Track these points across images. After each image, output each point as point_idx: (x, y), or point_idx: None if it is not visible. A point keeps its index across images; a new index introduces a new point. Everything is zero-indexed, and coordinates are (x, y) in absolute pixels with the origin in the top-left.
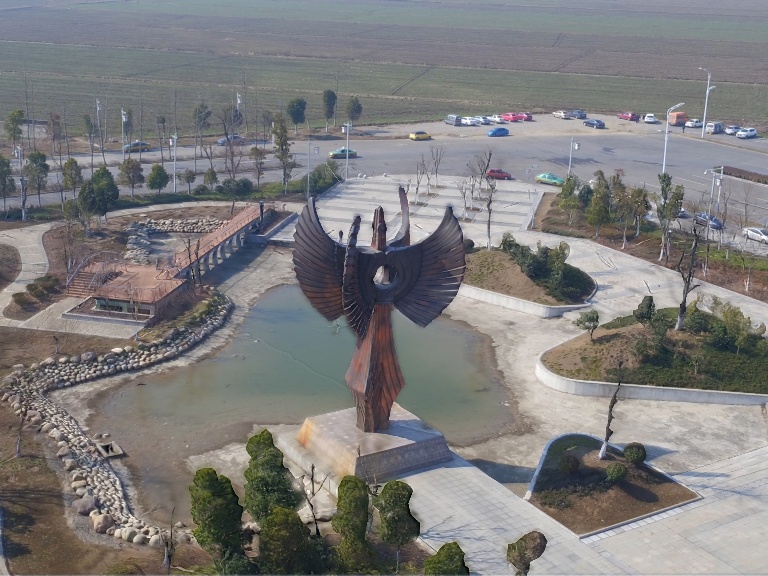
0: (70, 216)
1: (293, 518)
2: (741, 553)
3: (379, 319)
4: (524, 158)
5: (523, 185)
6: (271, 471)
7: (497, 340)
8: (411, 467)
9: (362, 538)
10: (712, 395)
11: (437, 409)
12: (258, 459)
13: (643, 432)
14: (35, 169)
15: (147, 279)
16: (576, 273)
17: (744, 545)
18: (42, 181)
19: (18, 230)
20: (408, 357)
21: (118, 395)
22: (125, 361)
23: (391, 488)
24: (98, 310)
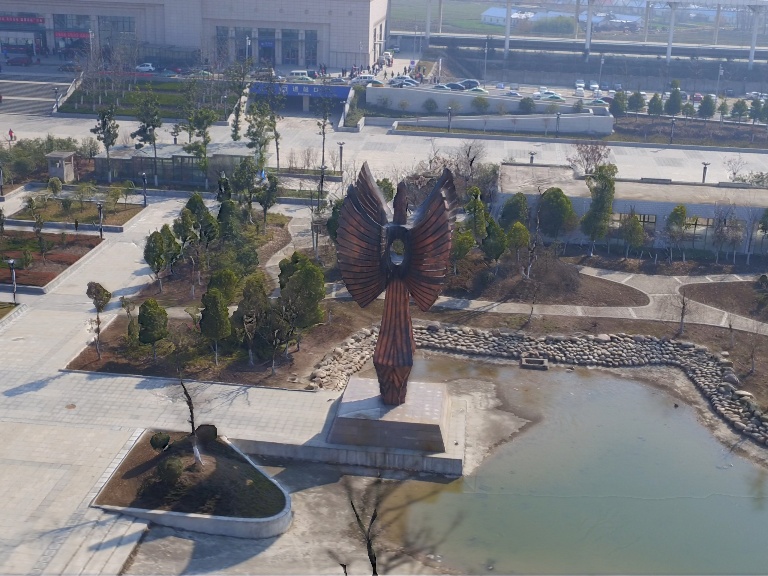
0: None
1: (248, 285)
2: (19, 473)
3: None
4: None
5: None
6: None
7: None
8: None
9: None
10: None
11: (474, 517)
12: None
13: None
14: None
15: None
16: None
17: (21, 480)
18: None
19: None
20: (657, 571)
21: (656, 392)
22: None
23: None
24: None
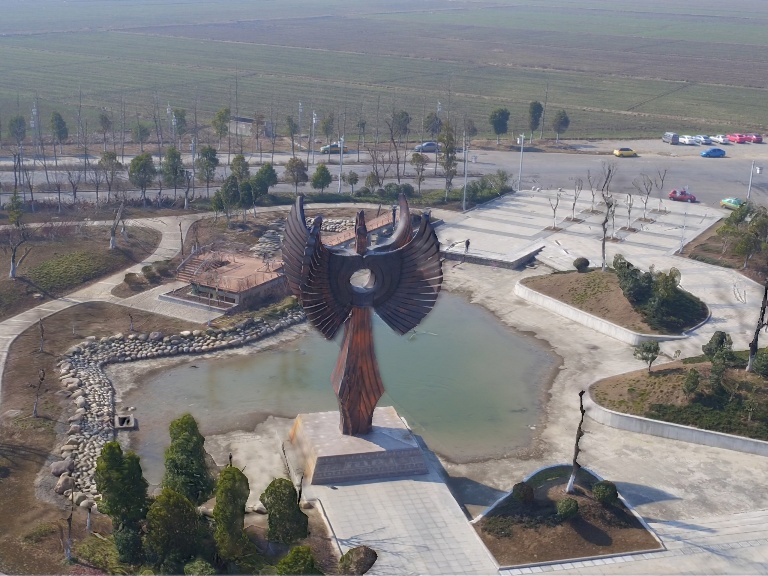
0: (217, 208)
1: (177, 501)
2: None
3: (358, 322)
4: (725, 181)
5: (704, 208)
6: (182, 454)
7: (568, 363)
8: (378, 475)
9: (232, 529)
10: (759, 445)
11: (459, 424)
12: (174, 441)
13: (658, 474)
14: (205, 162)
15: (249, 270)
16: (686, 302)
17: None
18: (210, 174)
19: (174, 218)
20: (466, 370)
21: (168, 374)
22: (189, 344)
23: (273, 485)
24: (192, 295)
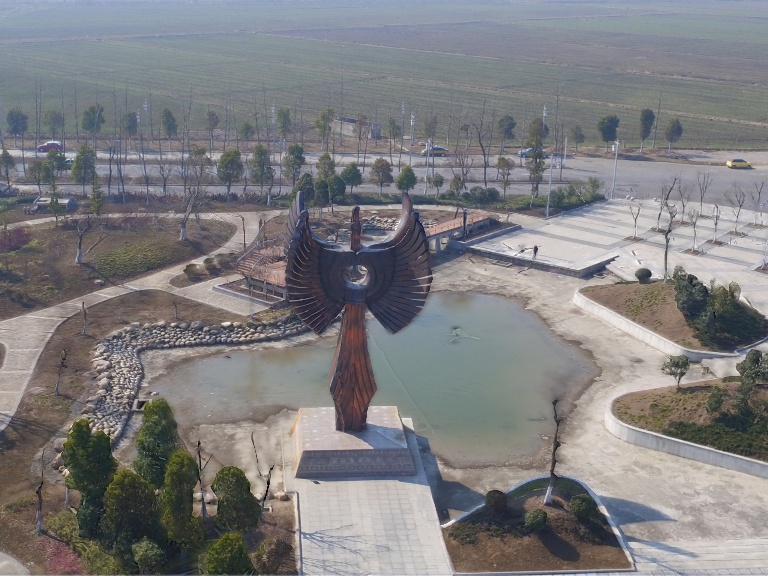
0: None
1: (132, 481)
2: None
3: (352, 319)
4: None
5: None
6: (150, 437)
7: (605, 375)
8: (364, 472)
9: (177, 513)
10: None
11: (472, 428)
12: None
13: (660, 493)
14: (291, 160)
15: None
16: (745, 319)
17: None
18: (296, 172)
19: (255, 213)
20: (498, 376)
21: (200, 363)
22: (228, 335)
23: (222, 472)
24: (245, 288)
